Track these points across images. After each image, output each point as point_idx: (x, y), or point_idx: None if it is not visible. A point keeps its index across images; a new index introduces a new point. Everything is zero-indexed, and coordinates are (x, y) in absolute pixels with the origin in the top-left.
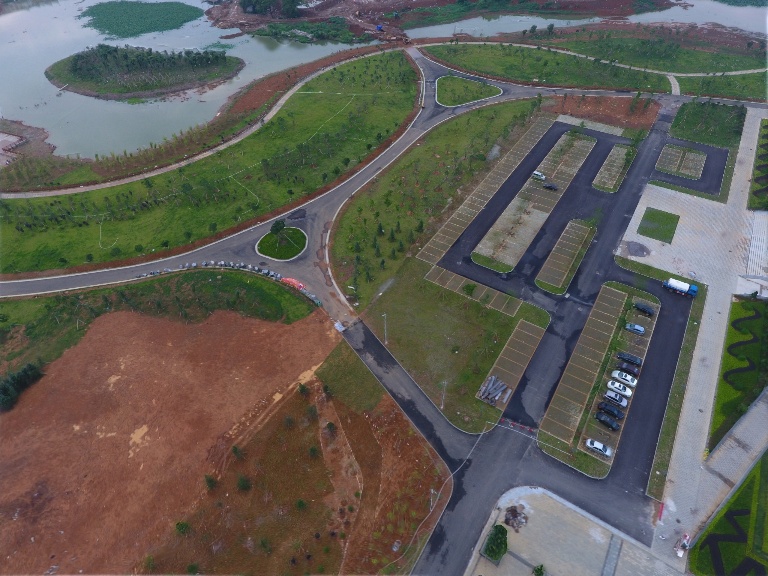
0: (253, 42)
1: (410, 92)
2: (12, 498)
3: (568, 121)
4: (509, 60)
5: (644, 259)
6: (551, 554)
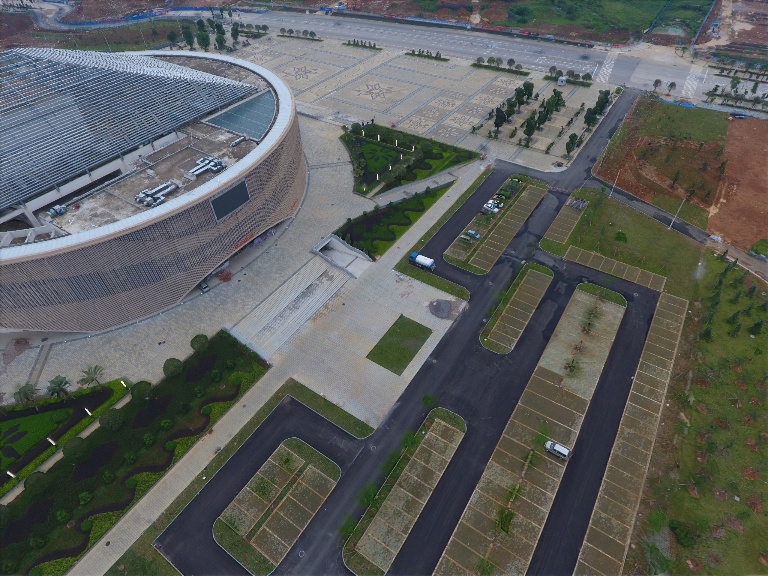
0: None
1: None
2: None
3: None
4: None
5: (439, 296)
6: None
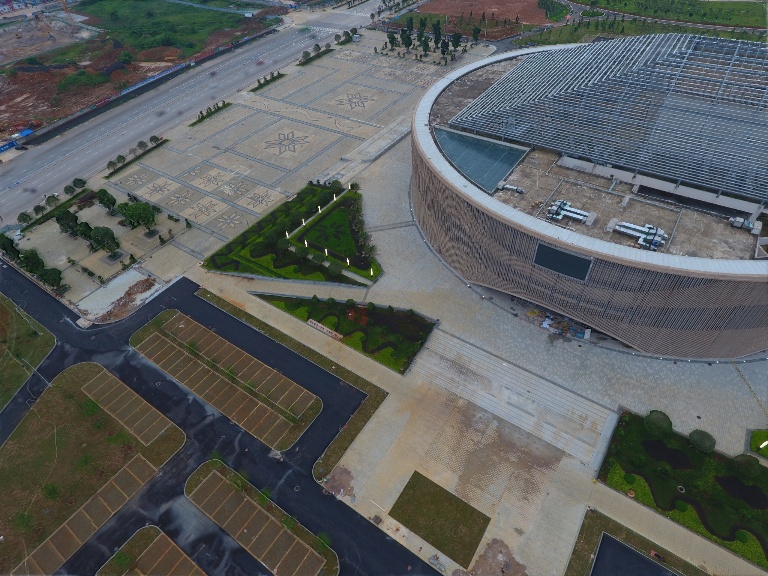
0: None
1: None
2: (473, 3)
3: None
4: None
5: None
6: (477, 49)
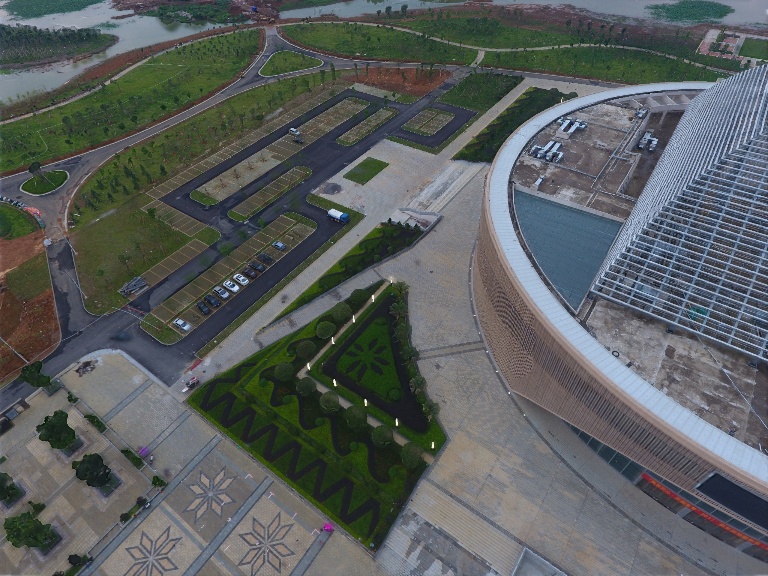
0: (139, 22)
1: (240, 64)
2: None
3: (358, 88)
4: (346, 37)
5: (331, 196)
6: (94, 390)
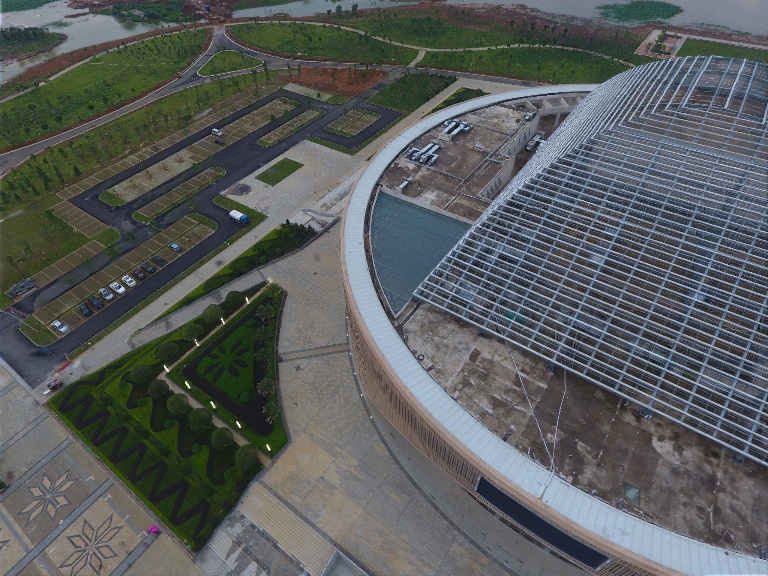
0: (92, 21)
1: (180, 64)
2: None
3: (291, 89)
4: (291, 36)
5: (239, 197)
6: None
